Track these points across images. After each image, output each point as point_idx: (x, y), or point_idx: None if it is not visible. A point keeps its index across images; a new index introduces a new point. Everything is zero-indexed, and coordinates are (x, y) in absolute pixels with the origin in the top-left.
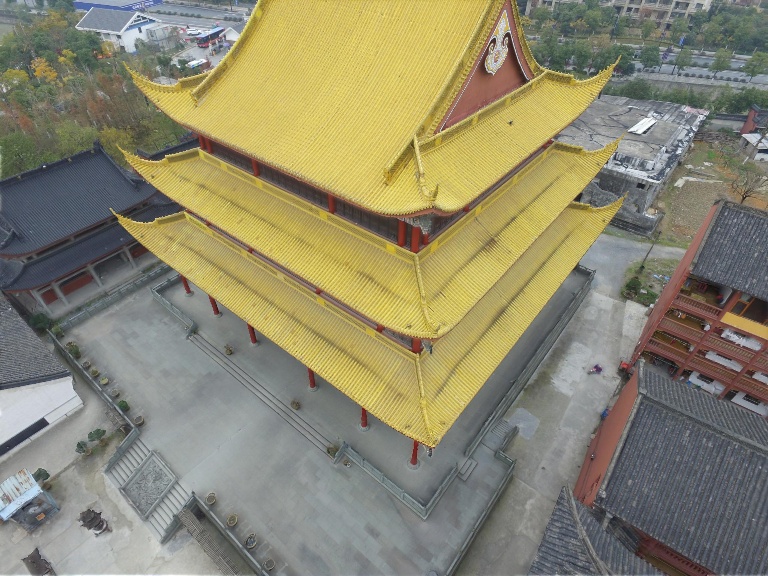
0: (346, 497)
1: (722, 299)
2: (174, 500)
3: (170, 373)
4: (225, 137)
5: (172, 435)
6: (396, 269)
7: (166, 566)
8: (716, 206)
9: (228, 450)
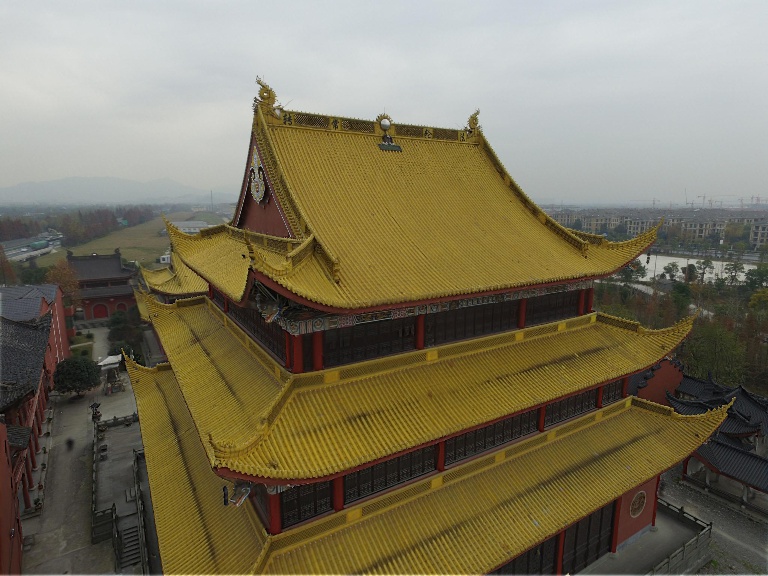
0: None
1: None
2: None
3: None
4: None
5: None
6: None
7: None
8: None
9: None
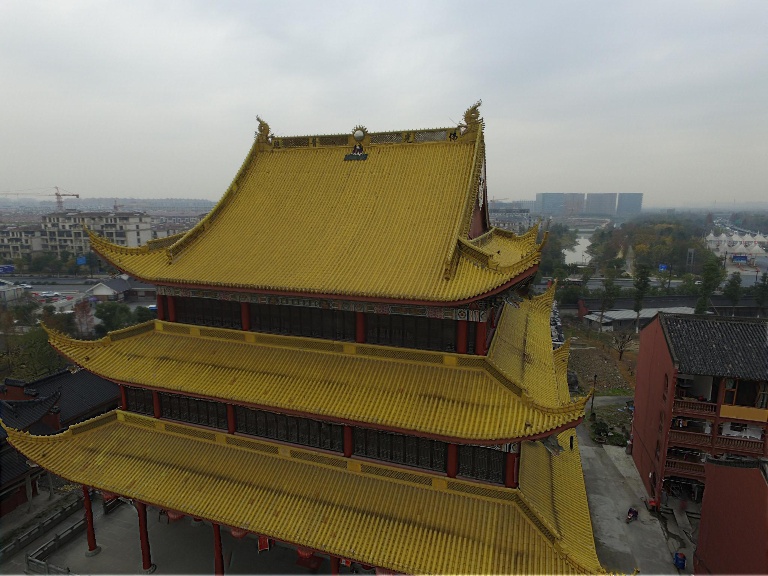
0: None
1: (705, 399)
2: None
3: None
4: (221, 280)
5: None
6: (466, 381)
7: None
8: (656, 320)
9: None
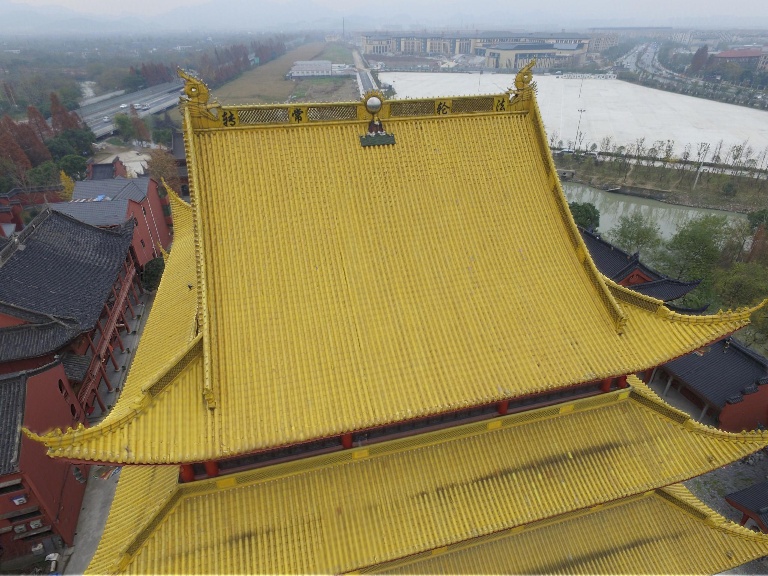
0: None
1: None
2: None
3: None
4: None
5: None
6: None
7: None
8: None
9: None
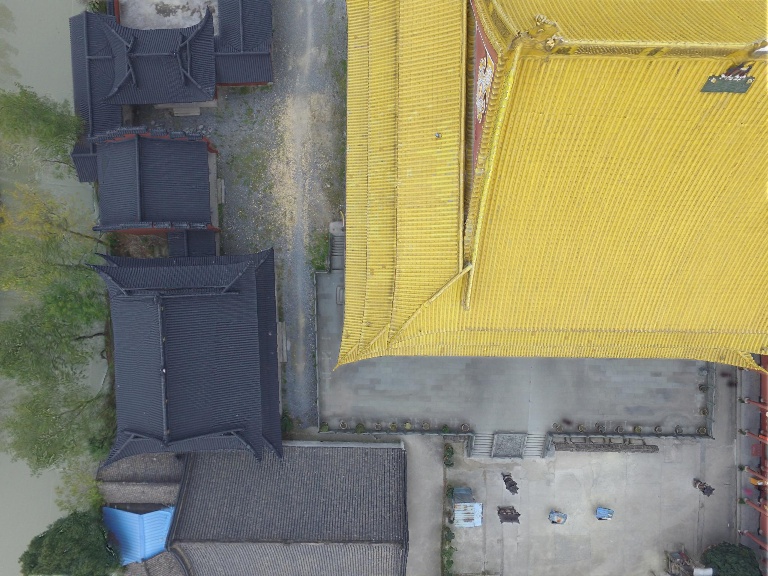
0: (629, 369)
1: None
2: (533, 441)
3: (440, 385)
4: None
5: (493, 417)
6: None
7: (557, 463)
8: None
9: (537, 398)
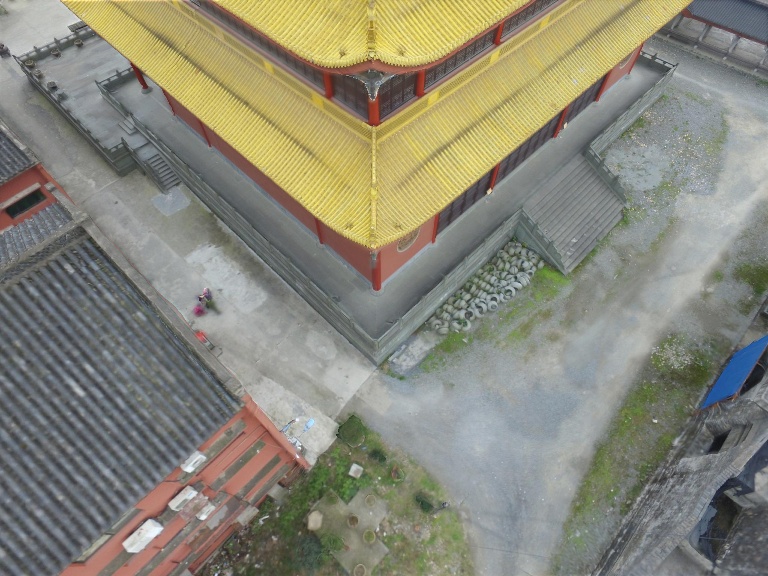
0: None
1: None
2: None
3: None
4: None
5: None
6: None
7: None
8: None
9: None
